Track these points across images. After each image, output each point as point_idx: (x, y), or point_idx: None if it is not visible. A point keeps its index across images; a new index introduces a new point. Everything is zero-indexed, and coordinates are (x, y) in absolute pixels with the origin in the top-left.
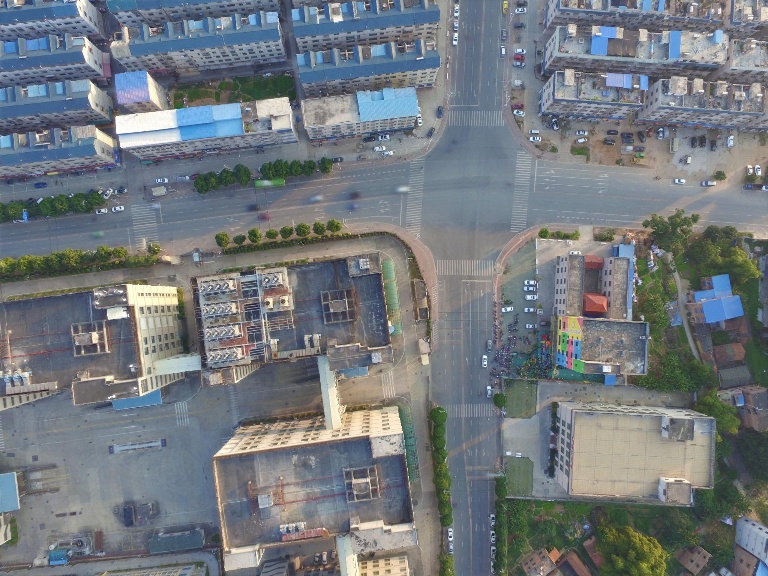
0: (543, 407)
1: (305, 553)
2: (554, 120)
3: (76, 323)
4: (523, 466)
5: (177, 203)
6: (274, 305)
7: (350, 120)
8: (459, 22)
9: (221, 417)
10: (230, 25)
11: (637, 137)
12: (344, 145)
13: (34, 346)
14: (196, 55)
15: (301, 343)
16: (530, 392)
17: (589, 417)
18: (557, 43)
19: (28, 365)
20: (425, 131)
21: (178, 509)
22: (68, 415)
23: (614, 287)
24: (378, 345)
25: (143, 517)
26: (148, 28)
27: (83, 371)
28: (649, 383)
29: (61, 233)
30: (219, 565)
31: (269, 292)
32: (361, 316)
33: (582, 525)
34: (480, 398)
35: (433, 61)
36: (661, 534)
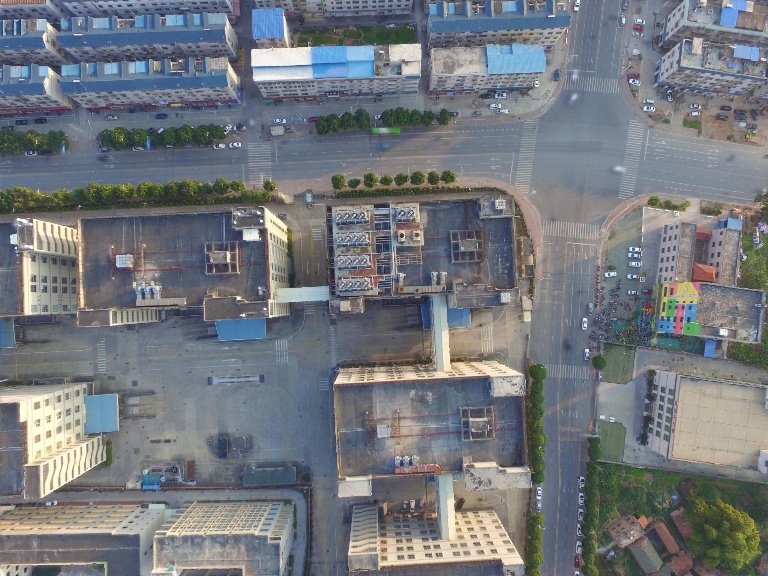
0: (640, 374)
1: (393, 500)
2: (669, 92)
3: (210, 242)
4: (616, 431)
5: (293, 144)
6: (405, 239)
7: (478, 71)
8: None
9: (320, 358)
10: None
11: (750, 115)
12: (460, 100)
13: (166, 261)
14: None
15: (427, 280)
16: (627, 358)
17: (693, 383)
18: (686, 12)
19: (159, 279)
20: (541, 93)
21: (271, 445)
22: (170, 343)
23: (724, 258)
24: (502, 288)
25: (236, 450)
26: None
27: (212, 290)
28: (750, 358)
29: (178, 164)
30: (308, 504)
31: (401, 226)
32: (487, 258)
33: (670, 495)
34: (577, 360)
35: (563, 20)
36: (748, 512)
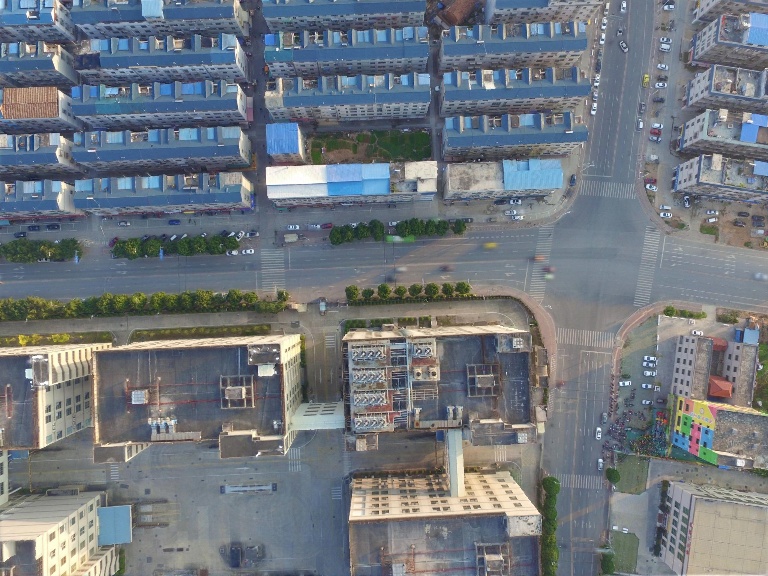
0: (653, 484)
1: None
2: (686, 197)
3: (225, 376)
4: (629, 542)
5: (306, 250)
6: (421, 375)
7: (494, 188)
8: (598, 92)
9: (333, 466)
10: (382, 84)
11: (767, 221)
12: (475, 206)
13: (181, 395)
14: (343, 109)
15: (442, 413)
16: (641, 468)
17: (708, 504)
18: (706, 126)
19: (174, 413)
20: (556, 198)
21: (283, 554)
22: (183, 451)
23: (740, 374)
24: (518, 422)
25: None
26: (302, 81)
27: (227, 423)
28: (765, 471)
29: (190, 271)
30: None
31: (417, 361)
32: (504, 392)
33: None
34: (591, 470)
35: (581, 135)
36: None
